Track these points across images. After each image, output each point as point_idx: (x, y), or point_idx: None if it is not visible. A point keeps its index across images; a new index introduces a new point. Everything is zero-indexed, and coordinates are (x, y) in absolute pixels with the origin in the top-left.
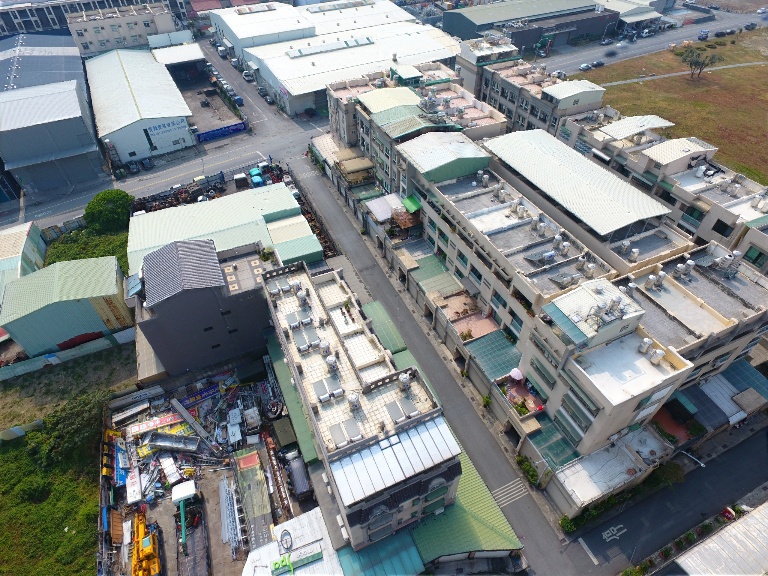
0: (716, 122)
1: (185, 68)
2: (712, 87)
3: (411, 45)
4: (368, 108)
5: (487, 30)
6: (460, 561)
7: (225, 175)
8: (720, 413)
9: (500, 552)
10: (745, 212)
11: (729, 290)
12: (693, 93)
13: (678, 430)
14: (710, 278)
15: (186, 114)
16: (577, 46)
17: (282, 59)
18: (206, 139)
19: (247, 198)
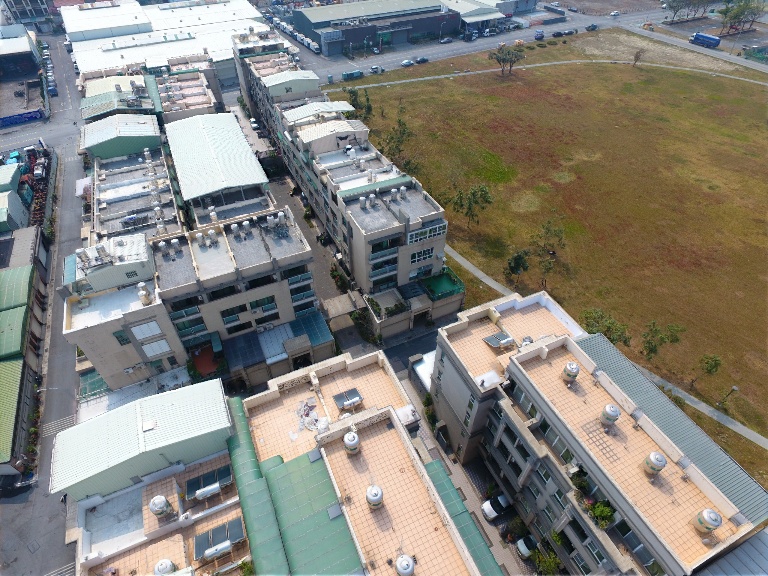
0: (495, 114)
1: (16, 60)
2: (516, 82)
3: None
4: (86, 93)
5: (324, 28)
6: None
7: None
8: (259, 354)
9: (6, 469)
10: (358, 184)
11: (265, 246)
12: (494, 88)
13: (211, 368)
14: (261, 236)
15: None
16: (416, 44)
17: (94, 52)
18: None
19: None
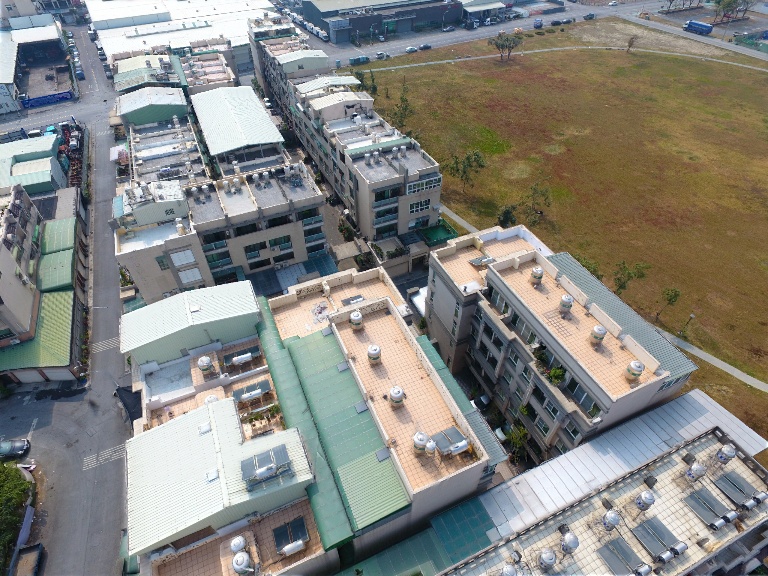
0: (493, 95)
1: (45, 48)
2: (514, 67)
3: (245, 28)
4: (118, 70)
5: (332, 17)
6: (39, 382)
7: (27, 132)
8: (277, 286)
9: (65, 374)
10: (364, 145)
11: (282, 192)
12: (493, 72)
13: None
14: (279, 185)
15: (6, 82)
16: (420, 32)
17: (118, 38)
18: (32, 105)
19: (16, 145)
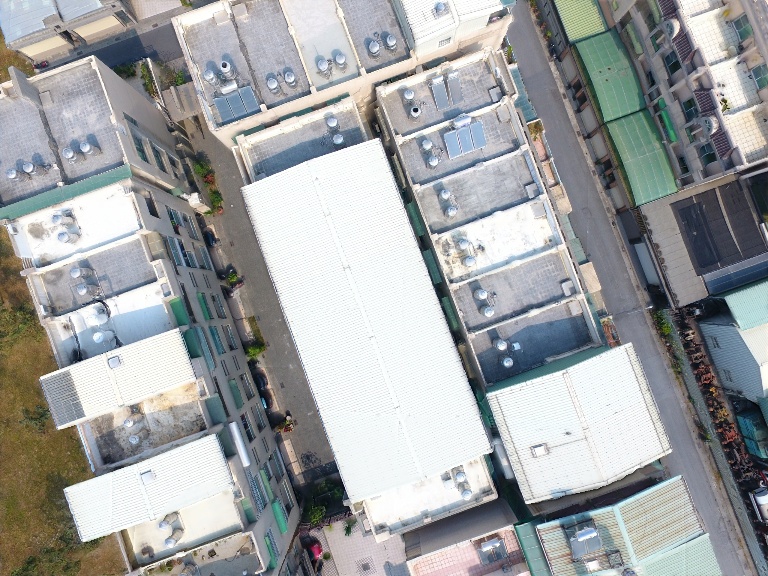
0: None
1: None
2: None
3: None
4: None
5: None
6: None
7: None
8: None
9: None
10: (99, 225)
11: None
12: None
13: None
14: None
15: None
16: None
17: None
18: None
19: None
